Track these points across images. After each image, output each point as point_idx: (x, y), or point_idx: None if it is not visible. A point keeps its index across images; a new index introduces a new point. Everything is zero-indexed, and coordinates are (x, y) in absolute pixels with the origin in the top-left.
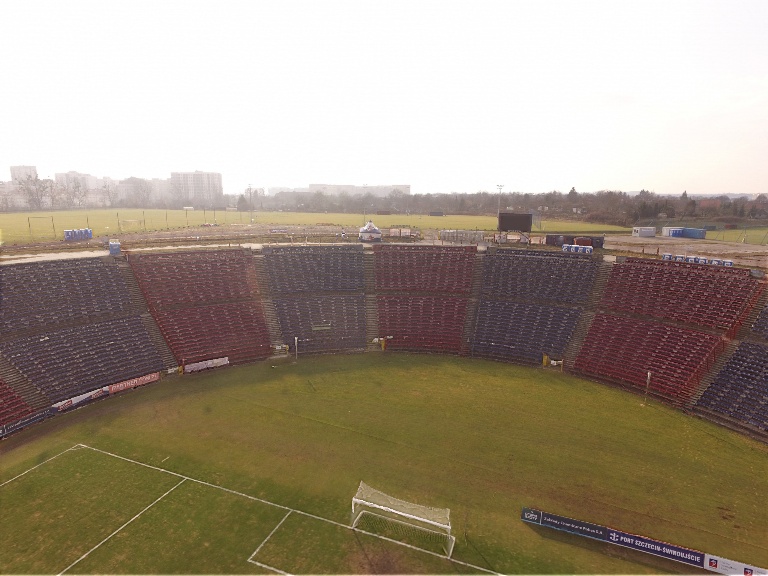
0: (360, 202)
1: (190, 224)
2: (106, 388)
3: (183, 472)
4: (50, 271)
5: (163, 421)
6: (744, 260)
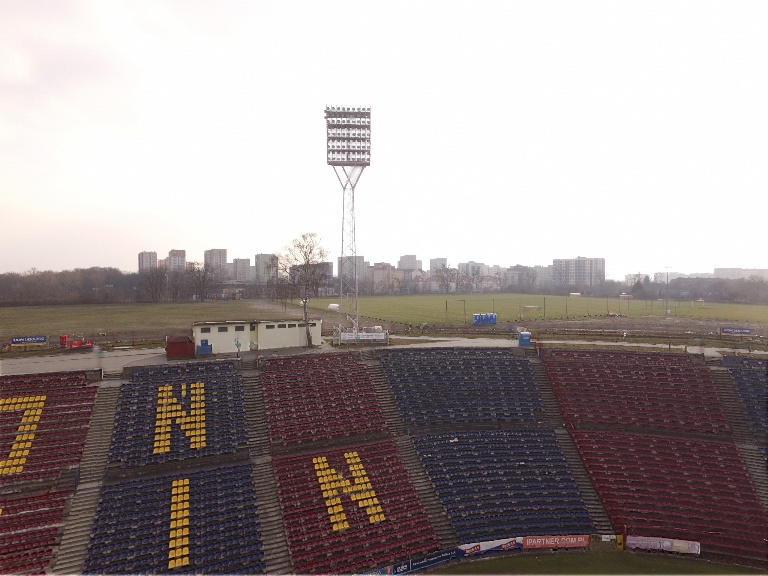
0: None
1: (589, 313)
2: (520, 539)
3: None
4: (464, 359)
5: None
6: None
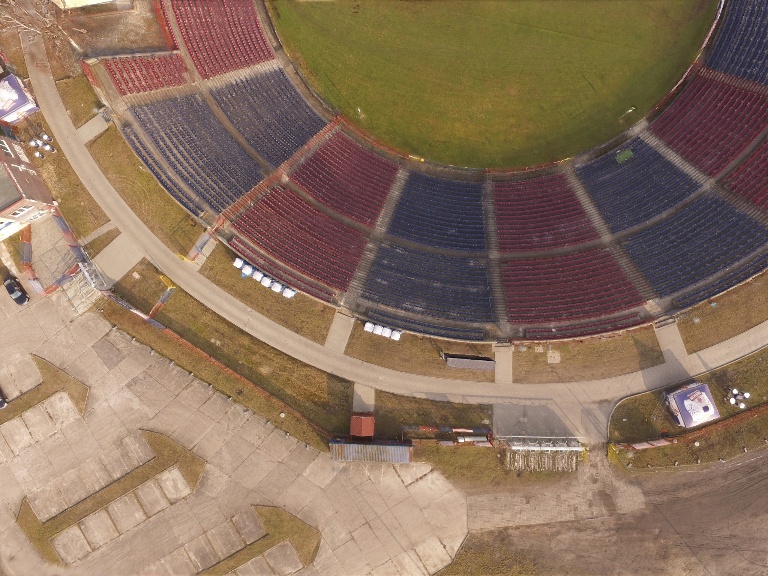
0: None
1: None
2: None
3: None
4: None
5: (655, 7)
6: (160, 422)
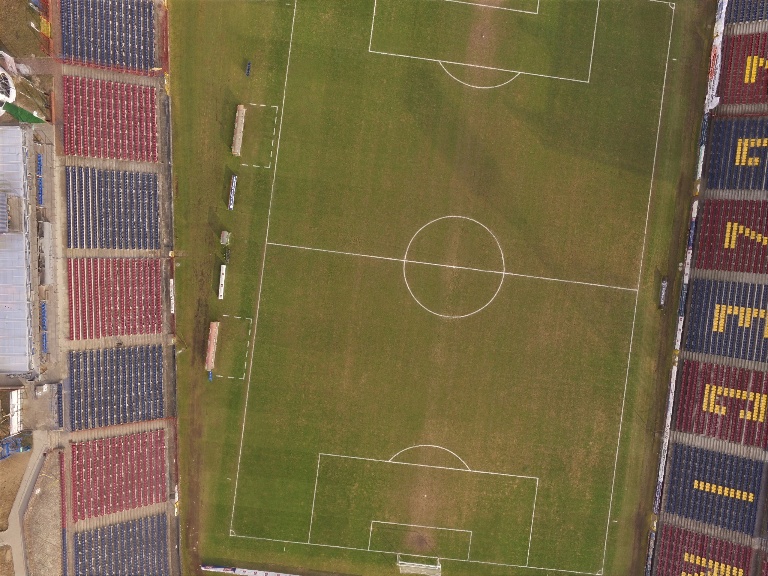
0: None
1: None
2: None
3: (531, 570)
4: None
5: None
6: None
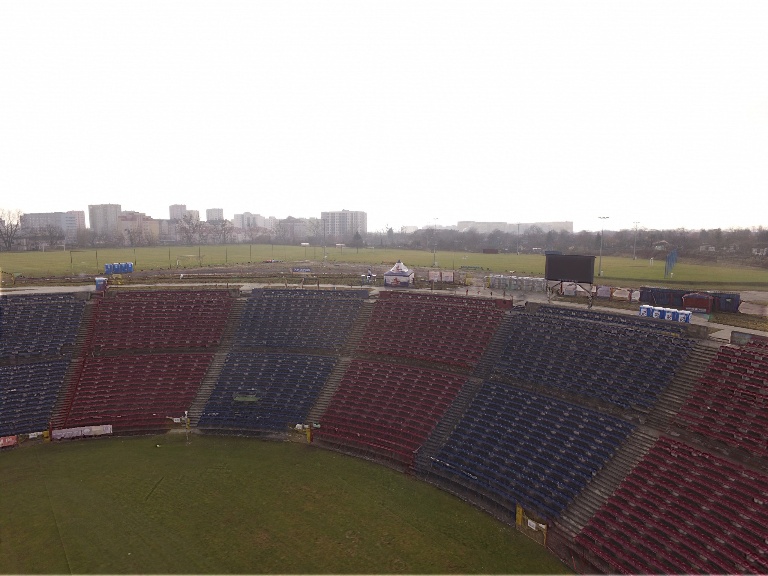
0: (430, 238)
1: (260, 260)
2: None
3: None
4: None
5: None
6: None
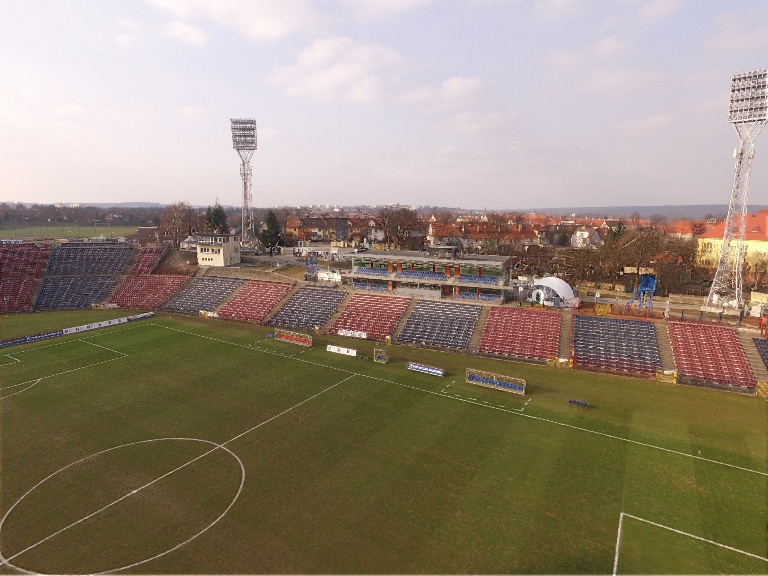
0: None
1: None
2: None
3: None
4: None
5: None
6: None
